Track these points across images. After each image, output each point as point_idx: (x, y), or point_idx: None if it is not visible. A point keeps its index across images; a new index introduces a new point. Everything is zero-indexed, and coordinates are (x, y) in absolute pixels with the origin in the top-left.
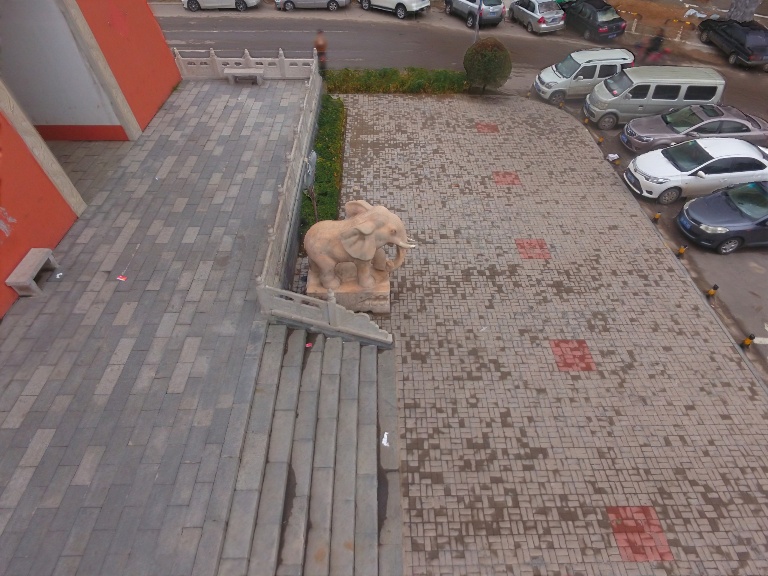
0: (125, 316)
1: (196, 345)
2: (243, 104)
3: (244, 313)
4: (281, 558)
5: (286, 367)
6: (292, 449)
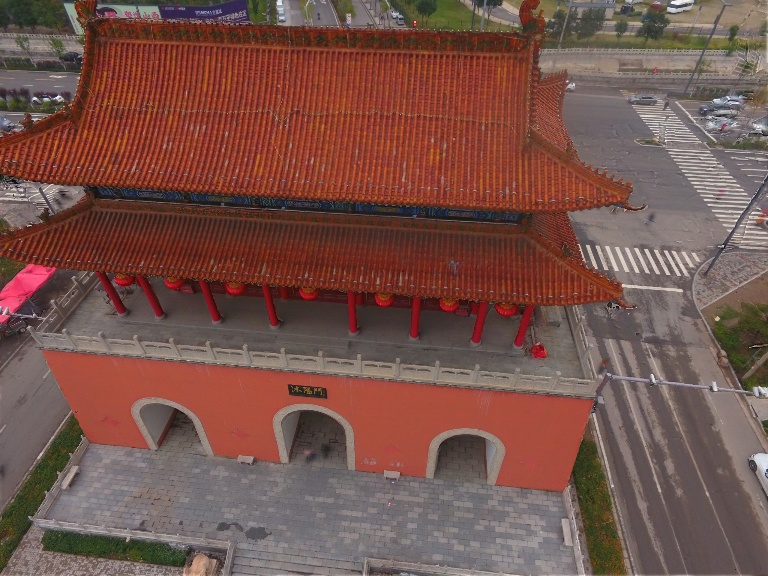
0: (371, 511)
1: (355, 538)
2: (534, 535)
3: (367, 553)
4: (290, 572)
5: (346, 571)
6: (318, 574)
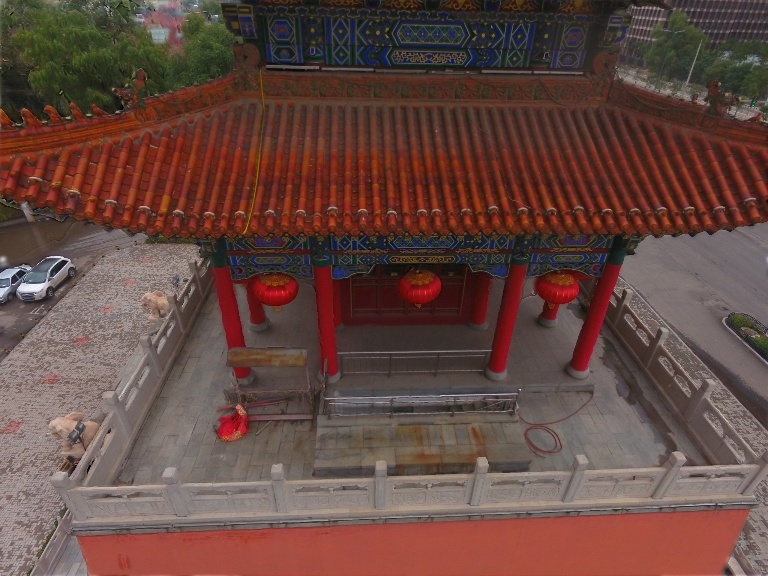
0: None
1: None
2: None
3: None
4: None
5: None
6: None
